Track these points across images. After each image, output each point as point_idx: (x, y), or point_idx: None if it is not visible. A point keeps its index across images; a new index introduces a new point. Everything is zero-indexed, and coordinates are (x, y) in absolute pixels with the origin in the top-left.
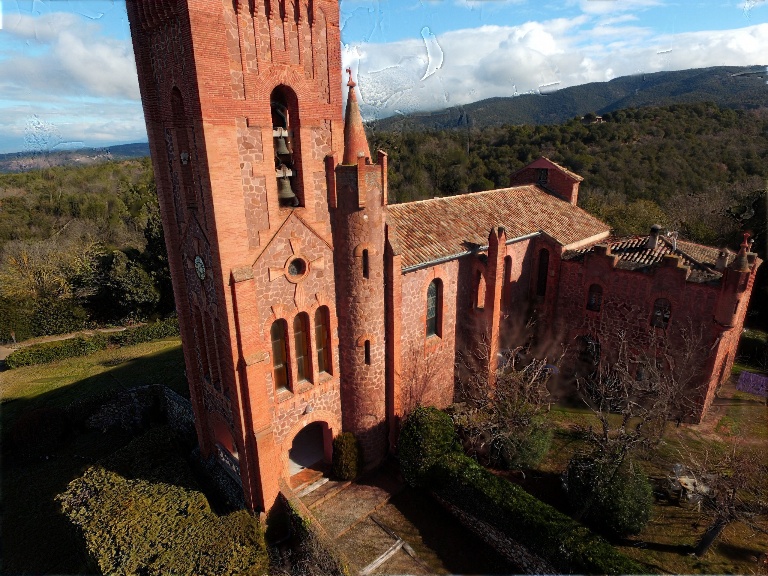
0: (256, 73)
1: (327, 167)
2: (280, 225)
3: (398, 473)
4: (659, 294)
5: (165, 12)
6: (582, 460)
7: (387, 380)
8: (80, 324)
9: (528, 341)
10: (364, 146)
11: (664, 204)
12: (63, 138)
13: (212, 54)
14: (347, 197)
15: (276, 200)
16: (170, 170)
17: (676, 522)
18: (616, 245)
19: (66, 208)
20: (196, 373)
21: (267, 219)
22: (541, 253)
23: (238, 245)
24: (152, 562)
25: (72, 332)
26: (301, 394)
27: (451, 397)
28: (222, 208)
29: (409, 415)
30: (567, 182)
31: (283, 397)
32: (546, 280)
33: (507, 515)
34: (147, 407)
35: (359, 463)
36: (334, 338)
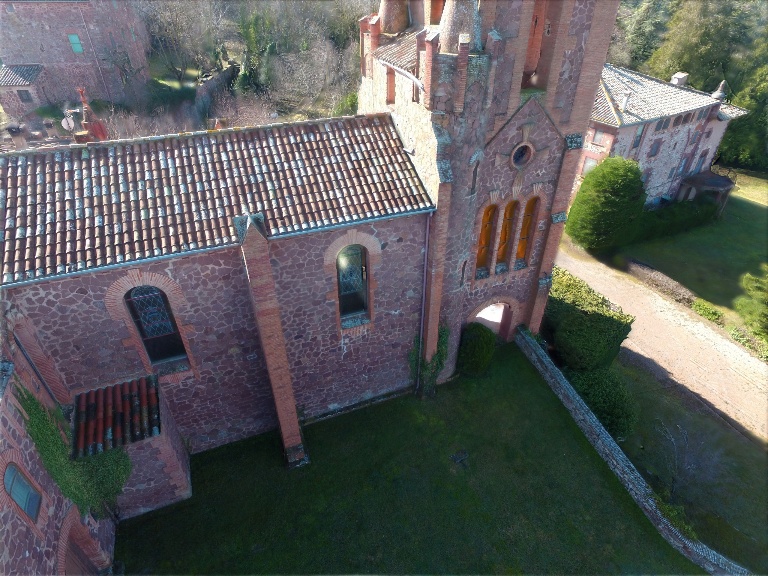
0: None
1: None
2: None
3: None
4: None
5: None
6: None
7: None
8: None
9: None
10: None
11: None
12: None
13: None
14: None
15: None
16: None
17: None
18: None
19: None
20: None
21: None
22: None
23: None
24: None
25: None
26: None
27: None
28: None
29: None
30: None
31: None
32: None
33: None
34: None
35: None
36: None
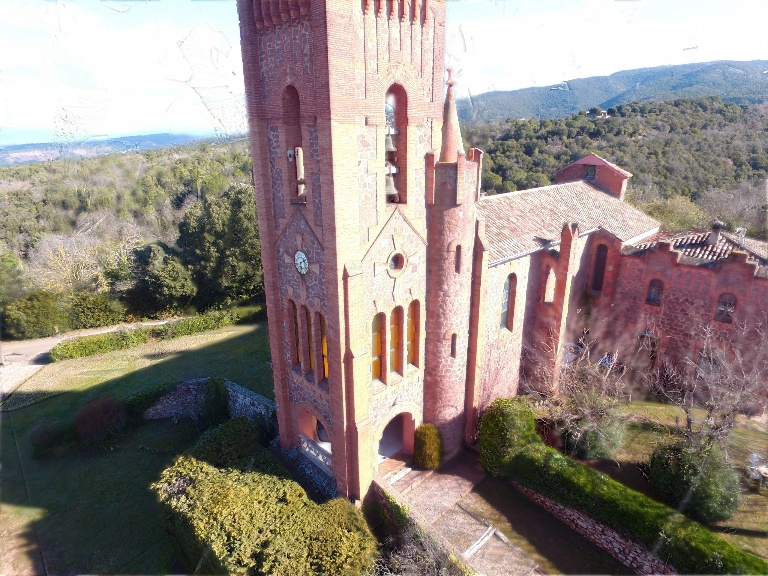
0: (375, 72)
1: (426, 164)
2: (386, 221)
3: (477, 463)
4: (724, 289)
5: (291, 12)
6: (668, 450)
7: (468, 372)
8: (117, 317)
9: (581, 335)
10: (460, 144)
11: (696, 200)
12: (88, 132)
13: (342, 54)
14: (445, 194)
15: (384, 197)
16: (271, 167)
17: (760, 509)
18: (675, 241)
19: (96, 202)
20: (283, 365)
21: (375, 215)
22: (598, 249)
23: (351, 241)
24: (265, 547)
25: (109, 325)
26: (393, 386)
27: (515, 389)
28: (341, 204)
29: (492, 406)
30: (616, 178)
31: (378, 389)
32: (603, 275)
33: (599, 503)
34: (208, 399)
35: (441, 453)
36: (422, 331)
